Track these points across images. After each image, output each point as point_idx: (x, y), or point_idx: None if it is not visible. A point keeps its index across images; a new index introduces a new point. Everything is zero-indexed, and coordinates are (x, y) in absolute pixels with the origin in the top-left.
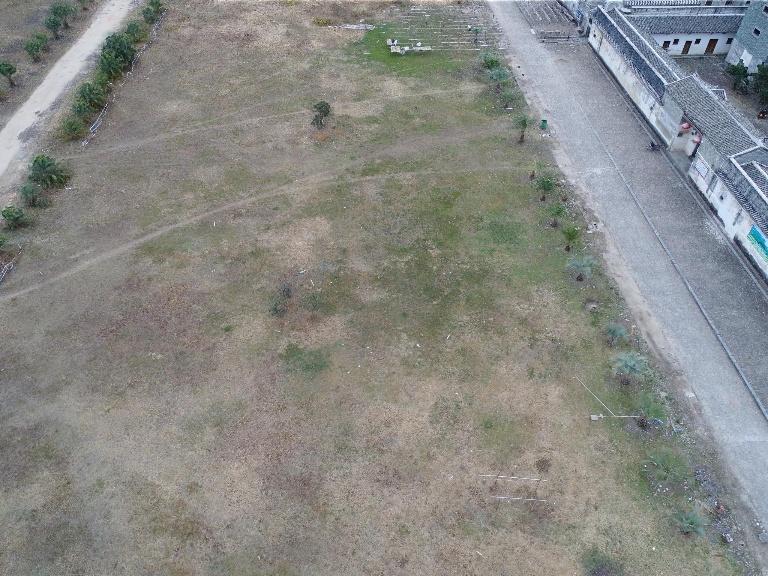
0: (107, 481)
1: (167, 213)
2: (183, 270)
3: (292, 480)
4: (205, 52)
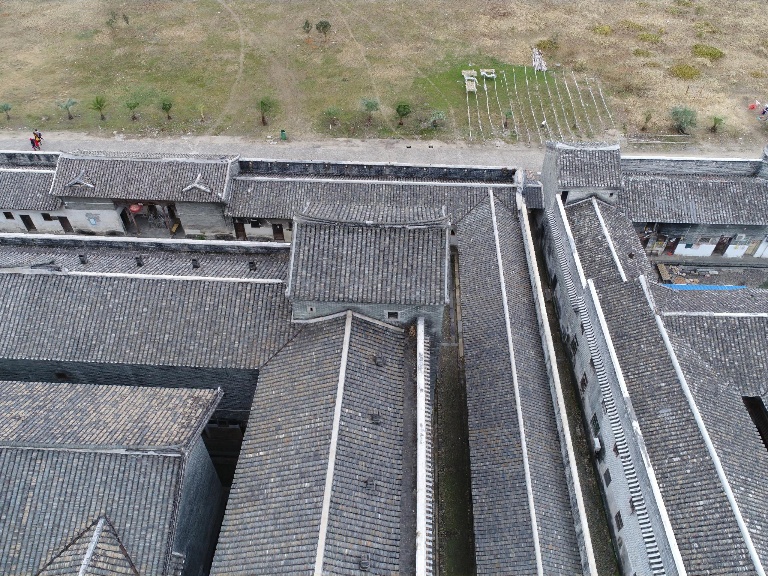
0: (64, 2)
1: (237, 1)
2: (182, 7)
3: (25, 31)
4: (467, 1)
